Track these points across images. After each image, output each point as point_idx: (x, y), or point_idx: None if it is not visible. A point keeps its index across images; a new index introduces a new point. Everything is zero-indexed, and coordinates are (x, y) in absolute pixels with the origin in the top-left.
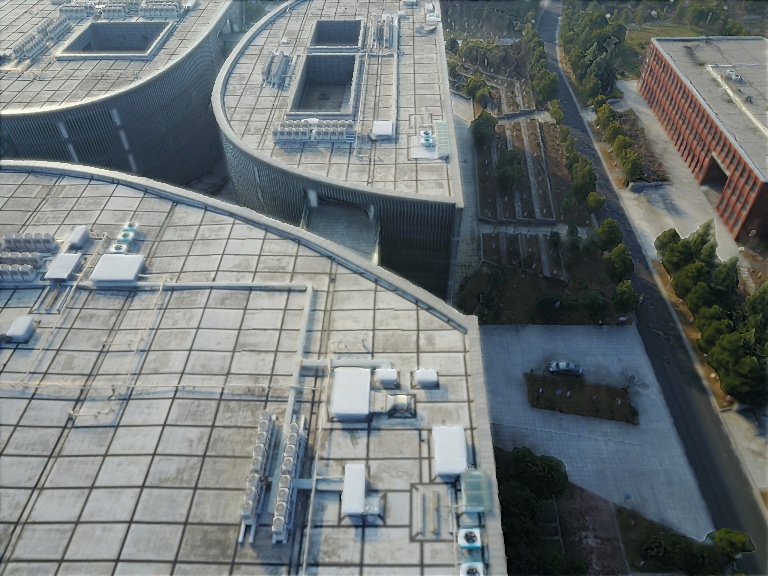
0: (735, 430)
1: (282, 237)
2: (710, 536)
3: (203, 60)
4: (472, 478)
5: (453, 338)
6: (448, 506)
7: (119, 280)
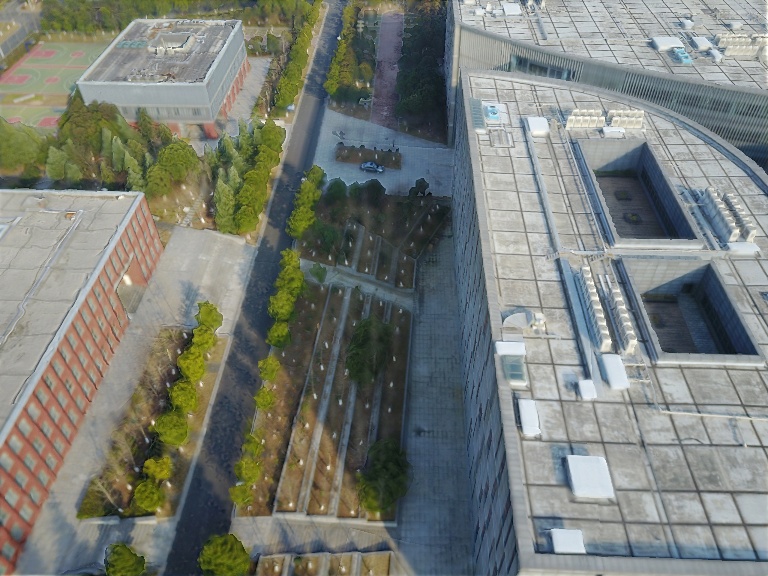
0: (283, 143)
1: None
2: None
3: None
4: None
5: None
6: None
7: None
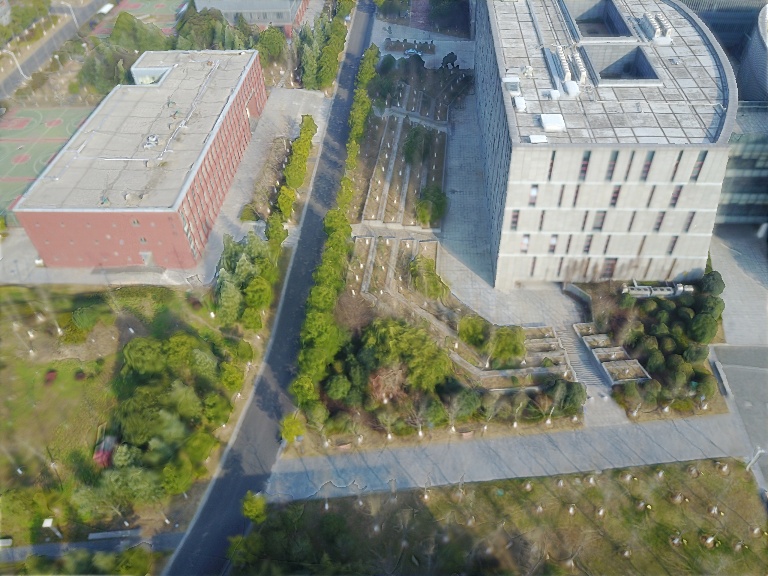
0: None
1: None
2: (384, 3)
3: (763, 72)
4: None
5: None
6: None
7: None
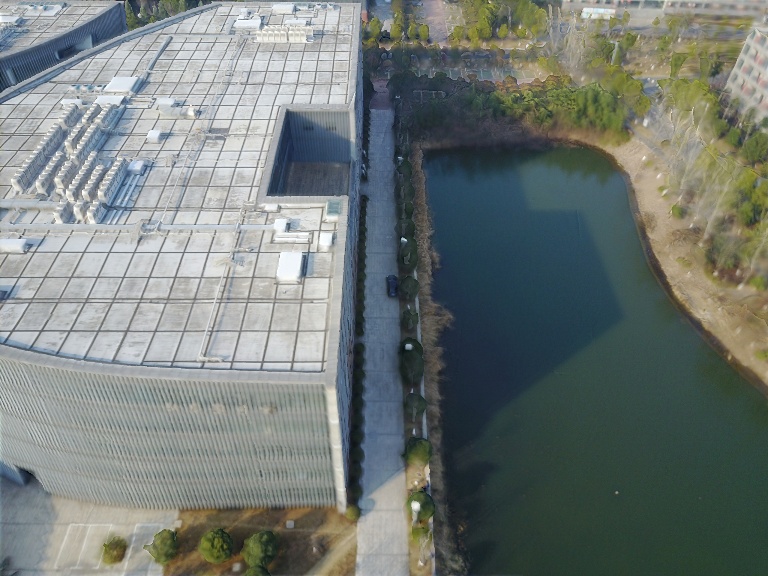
0: None
1: (118, 45)
2: None
3: None
4: (296, 4)
5: (223, 8)
6: (305, 11)
7: (136, 81)
